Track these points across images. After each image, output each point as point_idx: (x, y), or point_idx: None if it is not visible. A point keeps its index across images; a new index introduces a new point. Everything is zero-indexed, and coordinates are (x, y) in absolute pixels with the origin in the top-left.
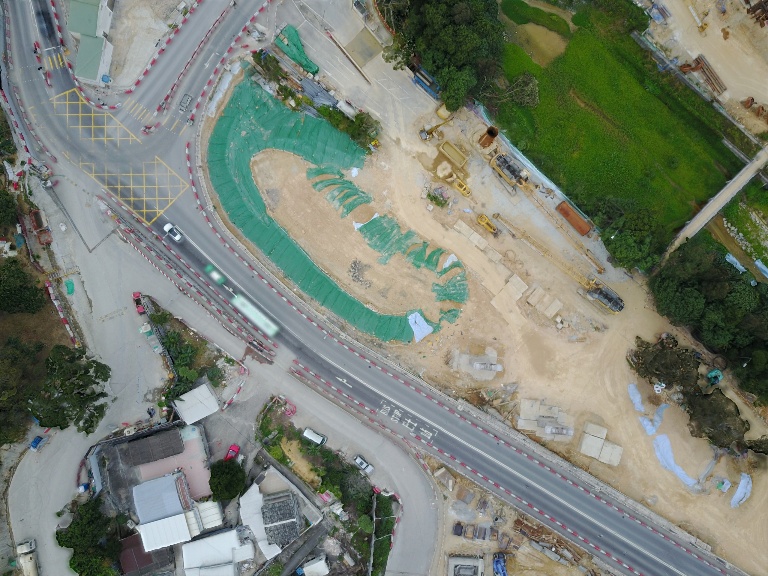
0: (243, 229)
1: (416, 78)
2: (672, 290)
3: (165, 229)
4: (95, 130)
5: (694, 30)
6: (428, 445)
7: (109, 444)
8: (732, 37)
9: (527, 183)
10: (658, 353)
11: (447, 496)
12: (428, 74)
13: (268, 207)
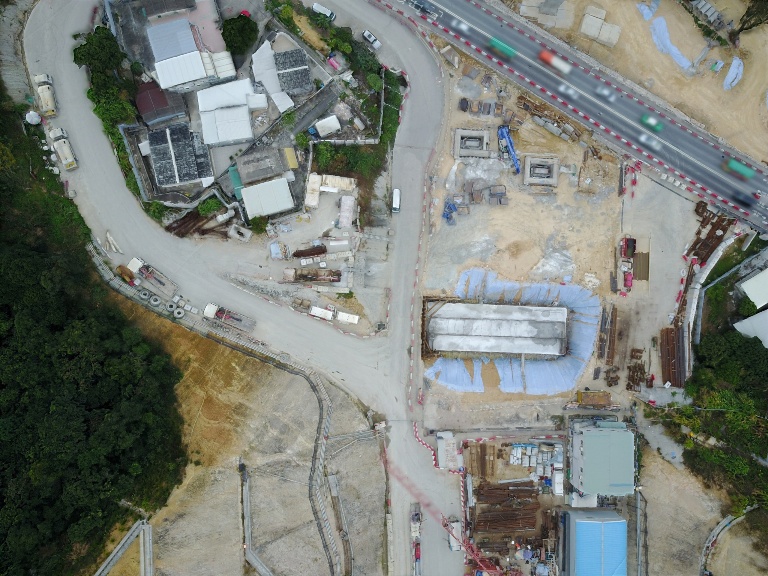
0: None
1: None
2: None
3: None
4: None
5: None
6: (434, 25)
7: (122, 2)
8: None
9: None
10: None
11: (453, 75)
12: None
13: None
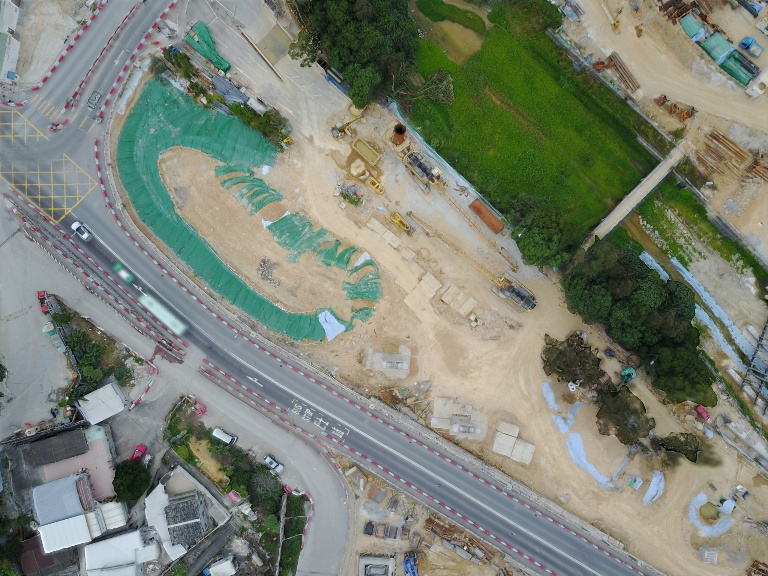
0: (153, 227)
1: (328, 75)
2: (581, 288)
3: (73, 227)
4: (2, 127)
5: (608, 27)
6: (340, 444)
7: (12, 445)
8: (645, 35)
9: (441, 181)
10: (562, 351)
11: (359, 495)
12: None
13: (176, 205)
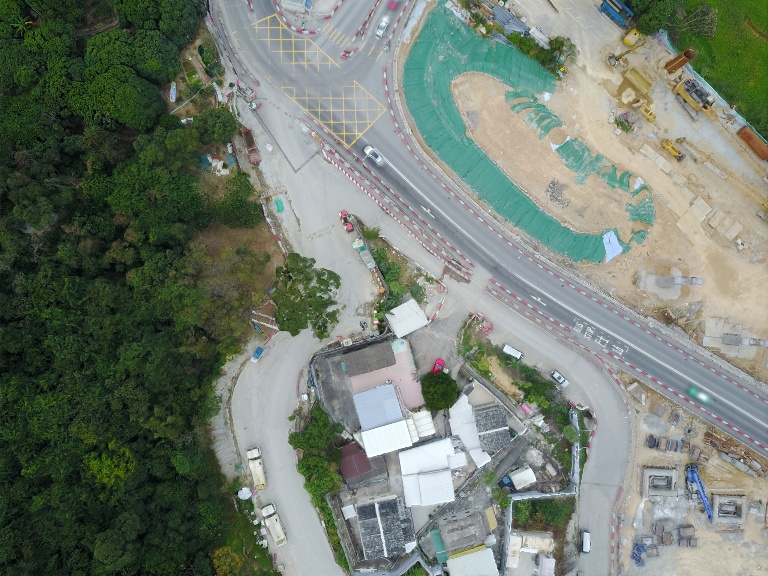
0: (439, 152)
1: (605, 6)
2: None
3: (365, 151)
4: (296, 55)
5: None
6: (620, 361)
7: (321, 357)
8: None
9: None
10: None
11: (639, 410)
12: (619, 1)
13: (469, 128)
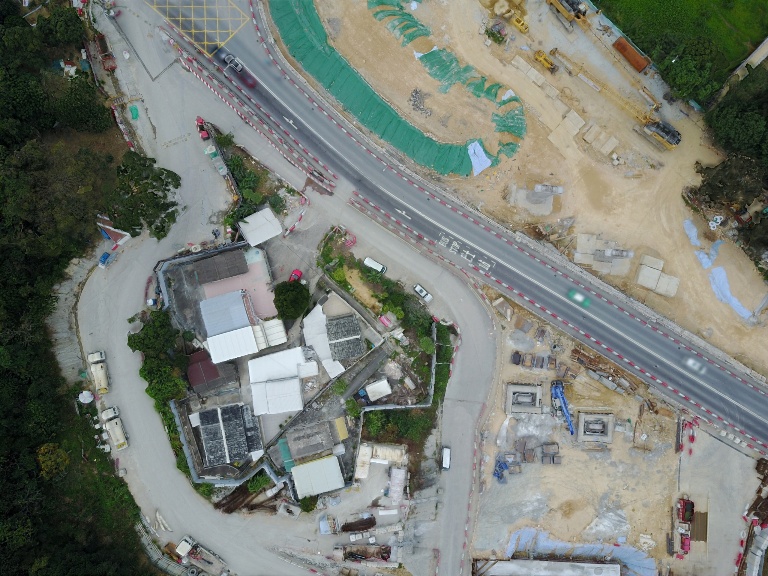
0: (303, 62)
1: None
2: (732, 116)
3: (226, 60)
4: None
5: None
6: (486, 276)
7: (174, 266)
8: None
9: None
10: None
11: (505, 326)
12: None
13: (329, 36)
